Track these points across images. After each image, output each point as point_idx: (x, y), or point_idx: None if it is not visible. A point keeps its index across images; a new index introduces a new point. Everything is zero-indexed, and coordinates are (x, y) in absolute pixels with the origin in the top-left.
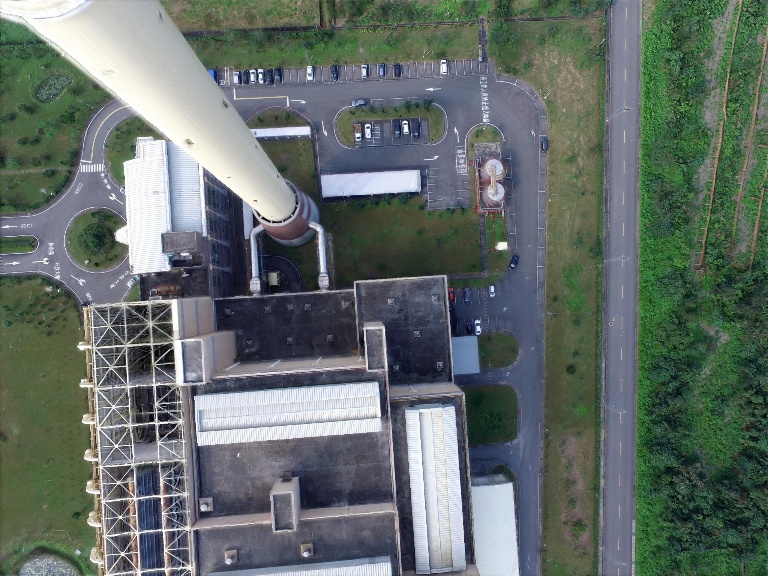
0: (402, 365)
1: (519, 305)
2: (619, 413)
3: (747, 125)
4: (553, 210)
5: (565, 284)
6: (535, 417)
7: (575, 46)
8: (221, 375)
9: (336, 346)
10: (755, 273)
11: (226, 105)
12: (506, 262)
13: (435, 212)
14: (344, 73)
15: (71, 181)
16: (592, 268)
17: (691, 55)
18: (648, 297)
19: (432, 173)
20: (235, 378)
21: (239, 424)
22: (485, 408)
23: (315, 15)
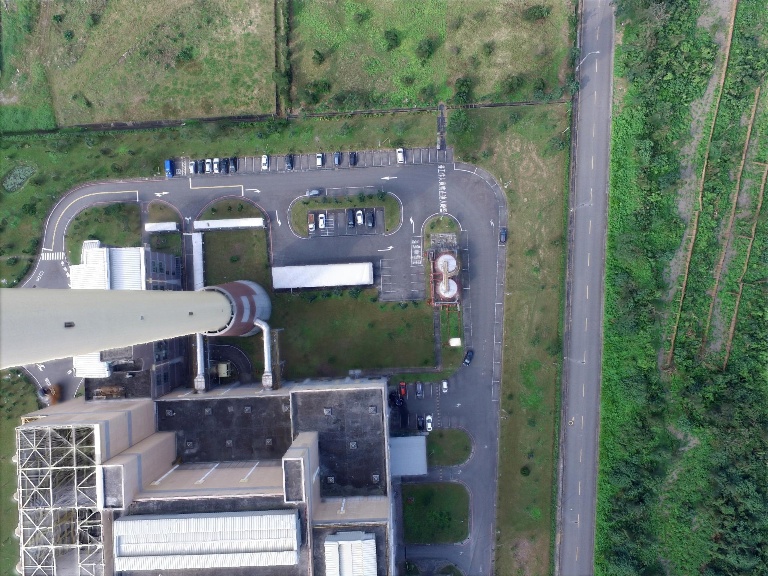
0: (337, 476)
1: (473, 401)
2: (577, 517)
3: (726, 214)
4: (511, 304)
5: (522, 381)
6: (487, 518)
7: (539, 133)
8: (143, 497)
9: (275, 450)
10: (727, 377)
11: (72, 325)
12: (460, 357)
13: (388, 304)
14: (299, 162)
15: (33, 269)
16: (551, 365)
17: (665, 141)
18: (611, 397)
19: (386, 264)
20: (157, 501)
21: (157, 550)
22: (435, 506)
23: (271, 103)
